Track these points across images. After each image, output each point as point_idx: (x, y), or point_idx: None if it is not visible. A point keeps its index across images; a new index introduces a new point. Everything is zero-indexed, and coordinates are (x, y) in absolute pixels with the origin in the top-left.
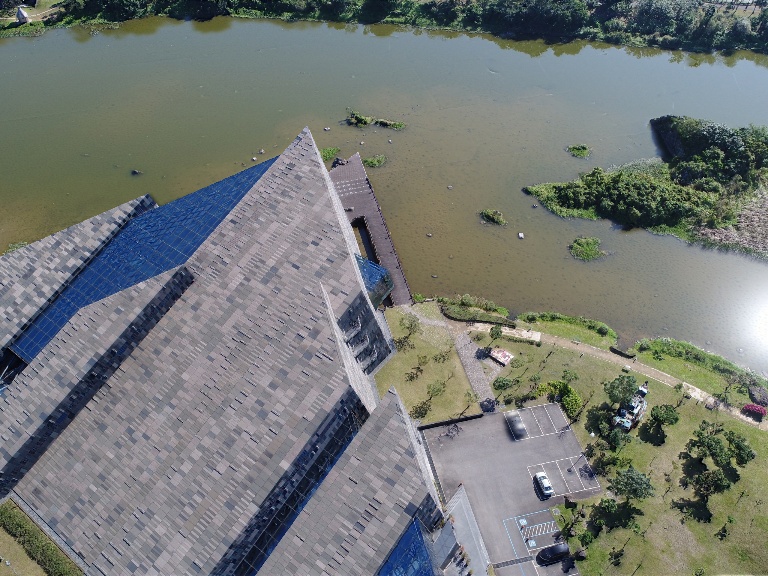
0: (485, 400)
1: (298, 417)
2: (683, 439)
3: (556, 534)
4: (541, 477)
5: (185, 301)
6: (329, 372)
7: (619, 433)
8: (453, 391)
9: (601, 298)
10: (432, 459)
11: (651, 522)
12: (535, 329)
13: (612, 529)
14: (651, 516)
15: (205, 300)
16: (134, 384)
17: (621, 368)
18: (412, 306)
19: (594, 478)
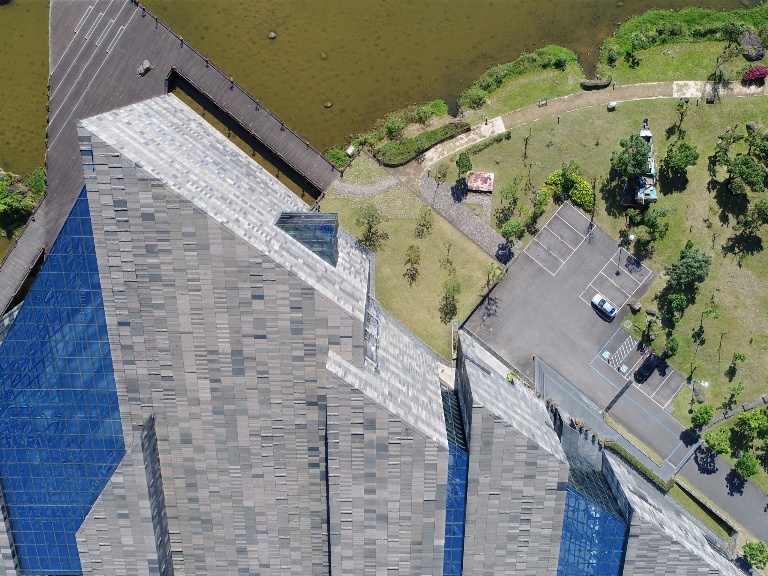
0: (498, 250)
1: (420, 503)
2: (702, 163)
3: (639, 347)
4: (600, 303)
5: (167, 441)
6: (418, 451)
7: (656, 219)
8: (463, 263)
9: (530, 3)
10: (493, 350)
11: (717, 289)
12: (491, 115)
13: (684, 312)
14: (712, 278)
15: (189, 428)
16: (202, 537)
17: (606, 109)
18: (343, 179)
19: (643, 267)
